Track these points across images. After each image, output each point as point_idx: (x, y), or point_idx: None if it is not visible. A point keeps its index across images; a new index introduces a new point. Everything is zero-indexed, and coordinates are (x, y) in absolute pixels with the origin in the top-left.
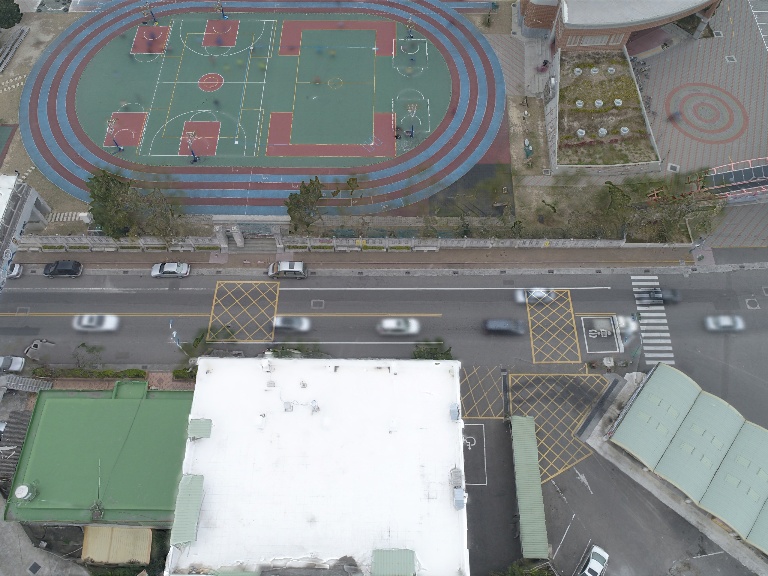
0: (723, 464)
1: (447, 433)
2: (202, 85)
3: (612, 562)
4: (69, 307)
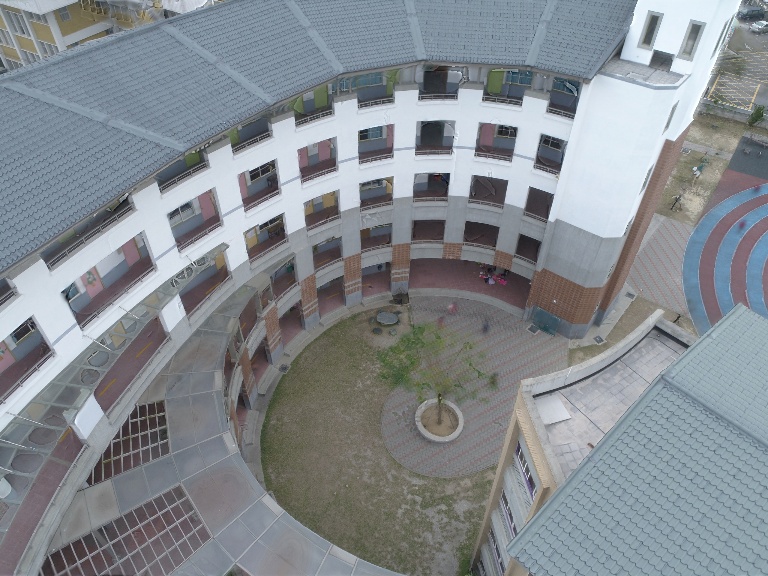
0: None
1: None
2: None
3: (745, 29)
4: None
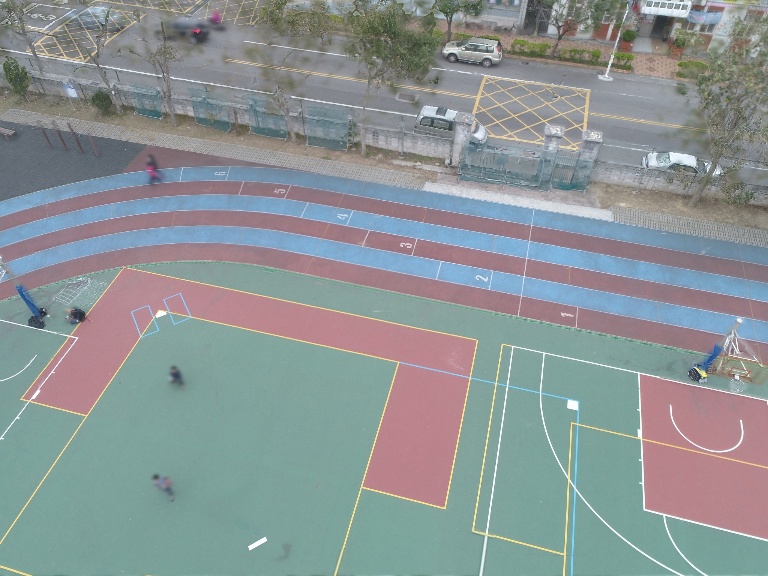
0: None
1: None
2: None
3: None
4: None
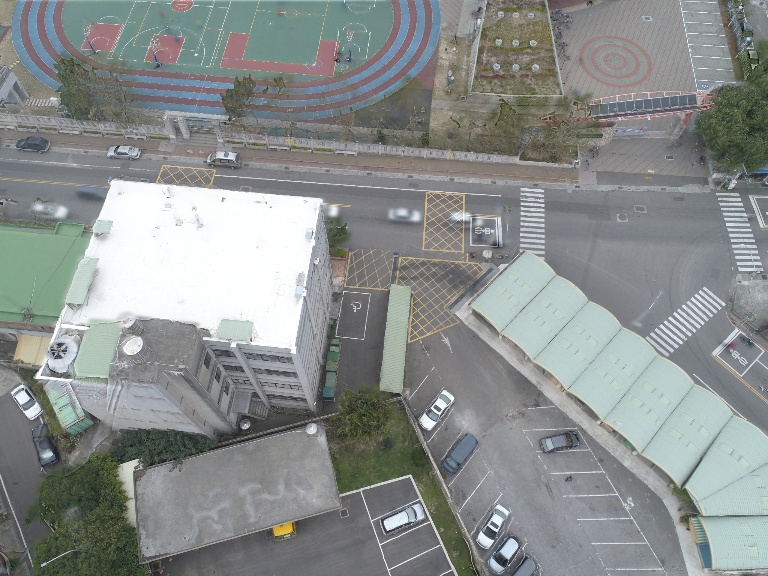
0: (561, 332)
1: (303, 251)
2: (174, 6)
3: (458, 406)
4: (34, 175)
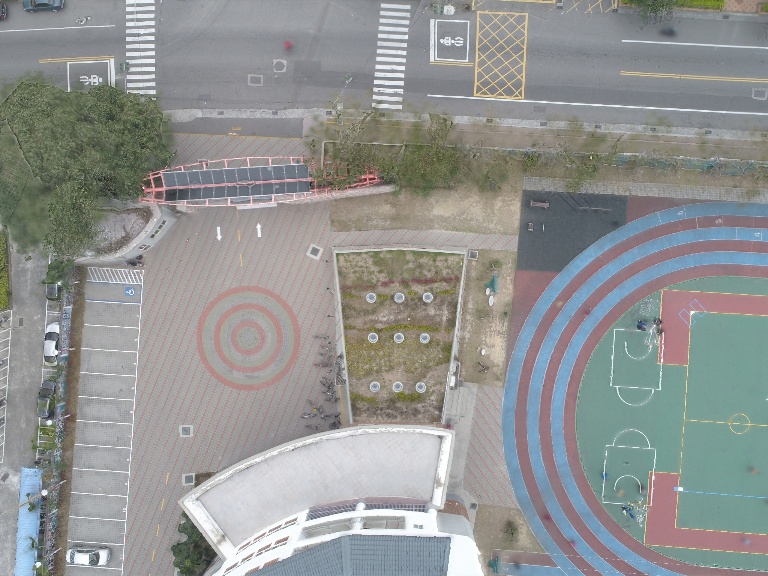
0: None
1: None
2: None
3: None
4: None
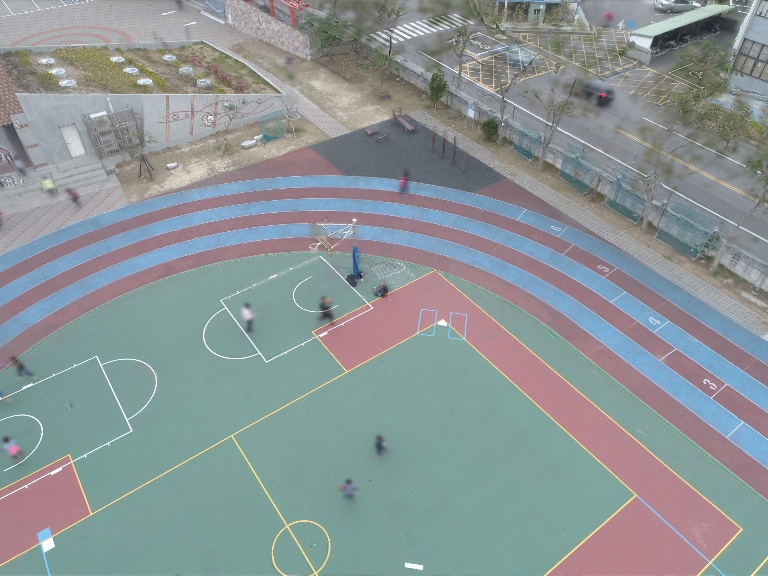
0: None
1: None
2: None
3: None
4: None
